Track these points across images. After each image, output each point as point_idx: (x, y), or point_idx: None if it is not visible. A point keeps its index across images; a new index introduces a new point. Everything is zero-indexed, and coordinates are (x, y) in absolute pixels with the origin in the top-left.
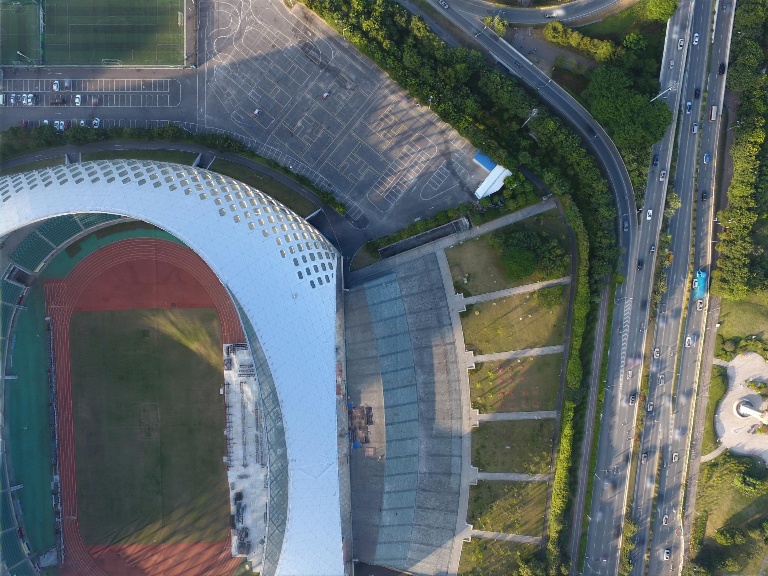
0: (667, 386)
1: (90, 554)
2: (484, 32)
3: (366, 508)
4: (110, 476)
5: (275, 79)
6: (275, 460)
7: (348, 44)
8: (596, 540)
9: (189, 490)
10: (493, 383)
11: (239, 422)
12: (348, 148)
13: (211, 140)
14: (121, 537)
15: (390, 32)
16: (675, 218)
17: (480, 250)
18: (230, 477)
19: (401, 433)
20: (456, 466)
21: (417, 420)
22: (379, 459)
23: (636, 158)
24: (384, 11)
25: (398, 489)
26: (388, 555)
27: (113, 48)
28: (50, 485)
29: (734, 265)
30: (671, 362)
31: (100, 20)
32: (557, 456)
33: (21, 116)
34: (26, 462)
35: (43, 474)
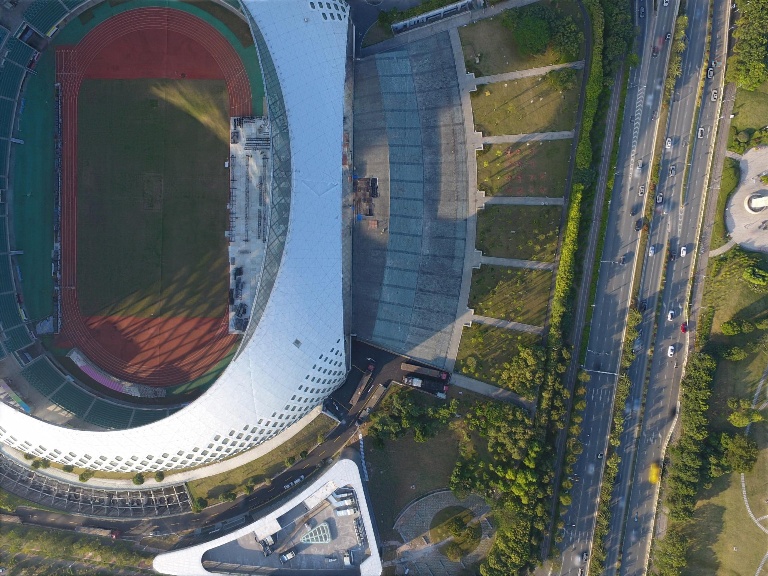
0: (678, 178)
1: (86, 325)
2: None
3: (367, 282)
4: (111, 246)
5: None
6: (279, 167)
7: None
8: (599, 333)
9: (189, 264)
10: (501, 165)
11: (243, 196)
12: None
13: None
14: (118, 309)
15: None
16: (692, 3)
17: (493, 30)
18: (231, 252)
19: (405, 210)
20: (460, 249)
21: (422, 200)
22: (382, 232)
23: None
24: None
25: (400, 267)
26: (387, 334)
27: None
28: (50, 253)
29: (751, 46)
30: (683, 153)
31: None
32: (563, 244)
33: None
34: (28, 229)
35: (44, 242)
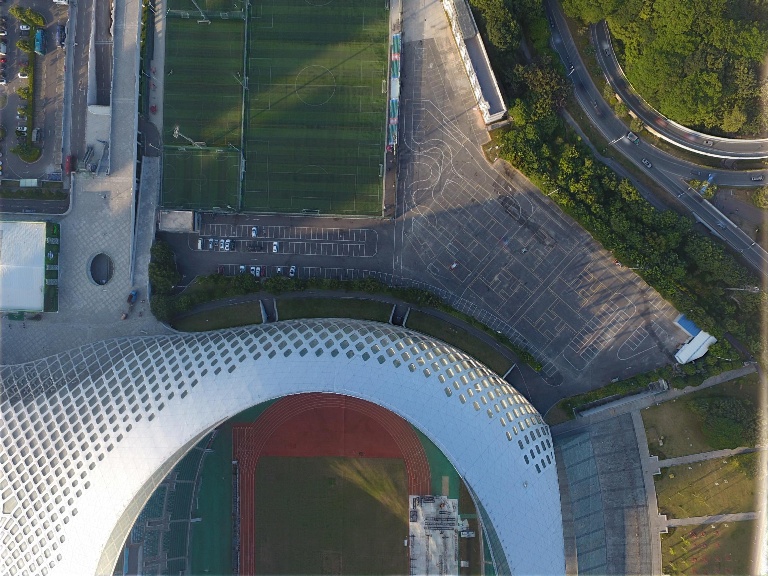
0: None
1: None
2: (687, 192)
3: None
4: None
5: (473, 233)
6: None
7: (549, 201)
8: None
9: None
10: (686, 549)
11: (423, 575)
12: (545, 304)
13: (412, 296)
14: None
15: (597, 194)
16: None
17: (677, 412)
18: None
19: None
20: None
21: None
22: None
23: None
24: (593, 174)
25: None
26: None
27: (312, 197)
28: None
29: None
30: None
31: (300, 169)
32: None
33: (217, 260)
34: None
35: None
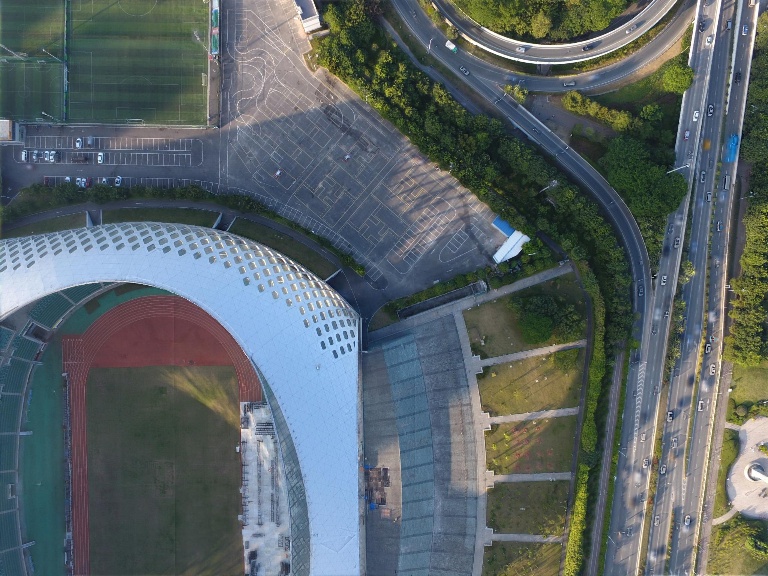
0: (680, 449)
1: None
2: (504, 99)
3: (381, 570)
4: (124, 533)
5: (297, 141)
6: (297, 535)
7: (370, 108)
8: None
9: (203, 548)
10: (509, 445)
11: (255, 480)
12: (368, 210)
13: (233, 202)
14: None
15: (412, 99)
16: (689, 284)
17: (497, 313)
18: (245, 536)
19: (417, 494)
20: (471, 527)
21: (433, 480)
22: (395, 521)
23: (652, 226)
24: (407, 78)
25: (413, 550)
26: None
27: (137, 107)
28: (63, 542)
29: (747, 333)
30: (684, 425)
31: (124, 79)
32: (571, 518)
33: (43, 172)
34: (39, 518)
35: (56, 531)
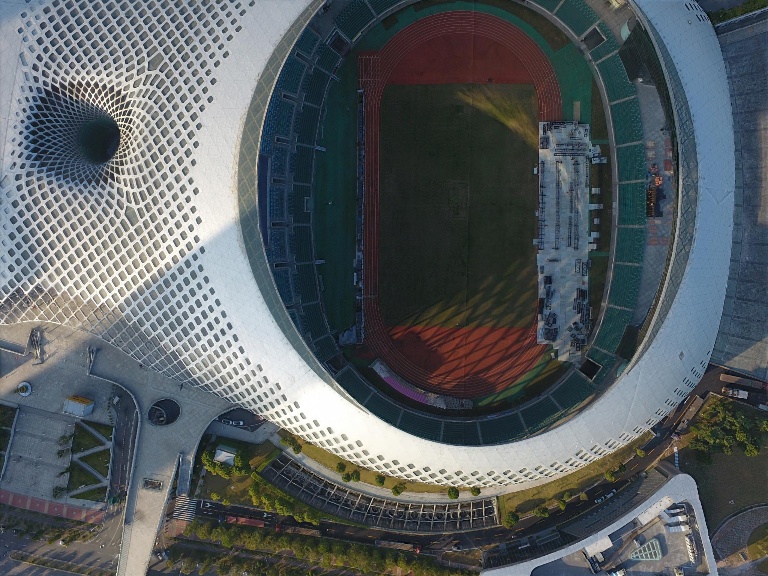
0: None
1: (389, 335)
2: None
3: None
4: (415, 255)
5: None
6: (687, 174)
7: None
8: None
9: (496, 272)
10: None
11: (552, 203)
12: None
13: None
14: (422, 319)
15: None
16: None
17: None
18: (540, 260)
19: None
20: None
21: (742, 206)
22: None
23: None
24: None
25: None
26: None
27: None
28: (352, 262)
29: None
30: None
31: None
32: None
33: None
34: (329, 238)
35: (346, 251)
